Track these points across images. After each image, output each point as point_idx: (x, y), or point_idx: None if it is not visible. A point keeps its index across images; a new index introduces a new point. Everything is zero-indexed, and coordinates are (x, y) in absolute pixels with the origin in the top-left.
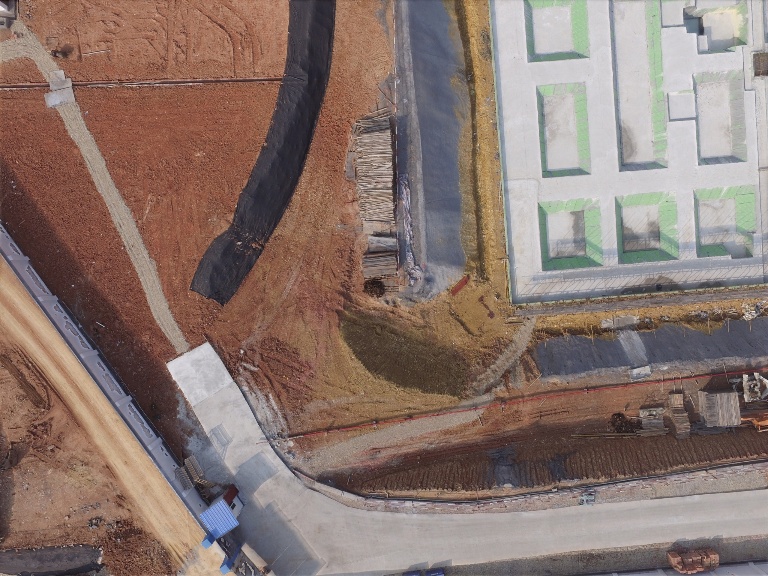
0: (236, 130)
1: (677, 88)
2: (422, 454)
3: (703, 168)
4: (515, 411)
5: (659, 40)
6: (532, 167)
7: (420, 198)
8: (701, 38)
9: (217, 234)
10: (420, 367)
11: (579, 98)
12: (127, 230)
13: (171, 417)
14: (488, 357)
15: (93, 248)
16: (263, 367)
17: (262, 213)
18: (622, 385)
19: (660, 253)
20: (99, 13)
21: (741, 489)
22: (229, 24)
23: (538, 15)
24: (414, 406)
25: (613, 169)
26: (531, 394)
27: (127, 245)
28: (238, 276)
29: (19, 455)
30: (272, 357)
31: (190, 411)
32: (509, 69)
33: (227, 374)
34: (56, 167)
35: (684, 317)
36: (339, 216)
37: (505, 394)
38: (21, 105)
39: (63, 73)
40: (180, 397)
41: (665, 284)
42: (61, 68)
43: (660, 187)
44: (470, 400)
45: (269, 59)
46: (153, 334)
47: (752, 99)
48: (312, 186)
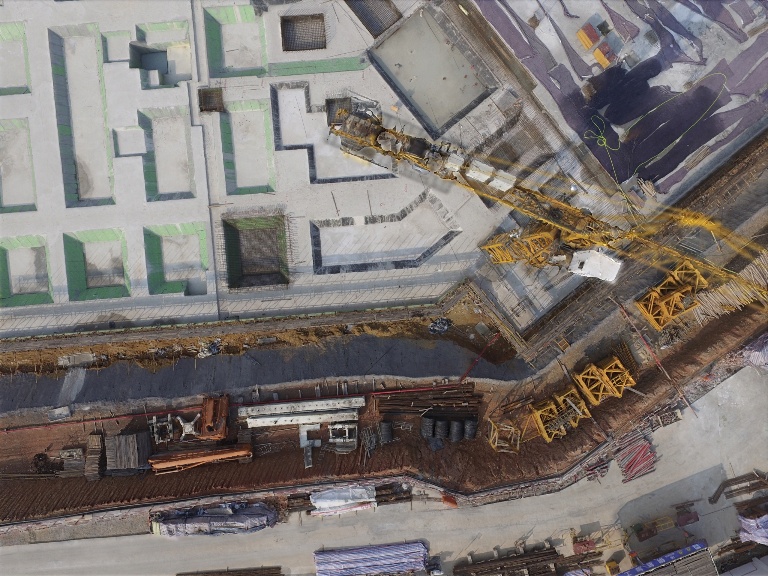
0: None
1: (122, 124)
2: None
3: (152, 204)
4: None
5: (102, 75)
6: None
7: None
8: (151, 73)
9: None
10: None
11: (28, 133)
12: None
13: None
14: None
15: None
16: None
17: None
18: (43, 425)
19: (120, 289)
20: None
21: (122, 534)
22: None
23: None
24: None
25: (59, 205)
26: None
27: None
28: None
29: None
30: None
31: None
32: None
33: None
34: None
35: (142, 354)
36: None
37: None
38: None
39: None
40: None
41: (118, 321)
42: None
43: (109, 223)
44: None
45: None
46: None
47: (199, 135)
48: None
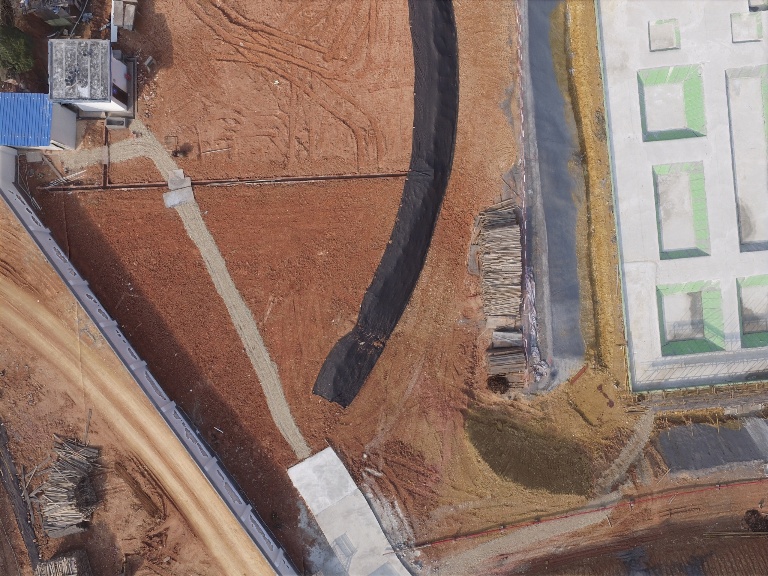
0: (360, 228)
1: None
2: (550, 558)
3: None
4: (644, 509)
5: None
6: (649, 249)
7: (546, 291)
8: None
9: (341, 335)
10: (543, 464)
11: (695, 177)
12: (248, 332)
13: (292, 526)
14: (610, 450)
15: (212, 351)
16: (387, 472)
17: (385, 311)
18: (756, 480)
19: None
20: (219, 111)
21: None
22: (352, 119)
23: (650, 92)
24: (541, 508)
25: (734, 250)
26: (660, 491)
27: (247, 348)
28: (360, 376)
29: (133, 567)
30: (396, 461)
31: (312, 520)
32: (624, 149)
33: (351, 481)
34: (174, 268)
35: None
36: (461, 310)
37: (633, 491)
38: (139, 205)
39: (182, 172)
40: (301, 505)
41: None
42: (180, 167)
43: None
44: (598, 499)
45: (394, 154)
46: (273, 439)
47: None
48: (433, 280)
